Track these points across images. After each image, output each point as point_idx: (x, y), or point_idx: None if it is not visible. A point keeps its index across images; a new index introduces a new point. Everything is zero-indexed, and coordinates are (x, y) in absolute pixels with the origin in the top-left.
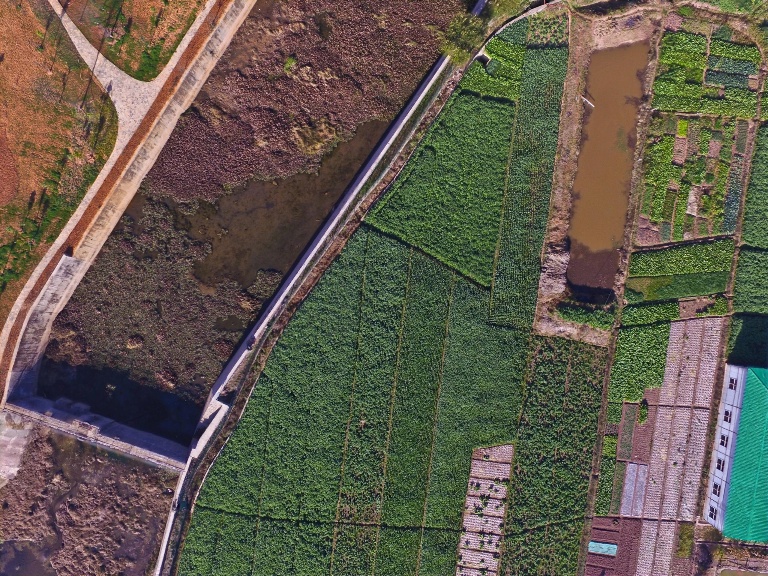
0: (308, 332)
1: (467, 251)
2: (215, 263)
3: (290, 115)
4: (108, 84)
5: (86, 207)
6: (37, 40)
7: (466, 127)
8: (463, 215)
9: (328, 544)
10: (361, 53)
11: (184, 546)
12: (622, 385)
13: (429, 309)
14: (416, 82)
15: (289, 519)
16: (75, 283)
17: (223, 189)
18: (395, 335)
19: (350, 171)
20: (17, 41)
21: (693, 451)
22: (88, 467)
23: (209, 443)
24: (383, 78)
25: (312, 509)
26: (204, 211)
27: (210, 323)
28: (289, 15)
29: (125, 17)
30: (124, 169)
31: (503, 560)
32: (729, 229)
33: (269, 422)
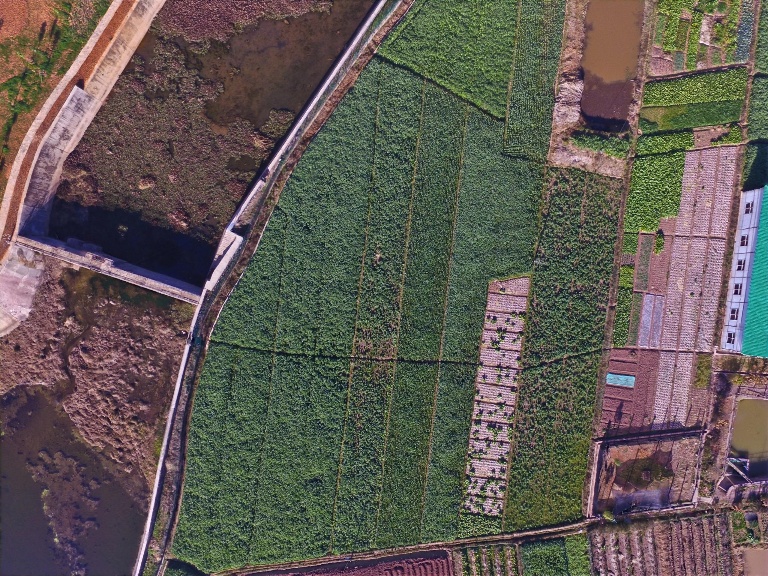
0: (322, 164)
1: (481, 82)
2: (227, 103)
3: None
4: None
5: (97, 39)
6: None
7: None
8: (476, 46)
9: (344, 379)
10: None
11: (199, 382)
12: (638, 214)
13: (443, 140)
14: None
15: (305, 354)
16: (86, 122)
17: (234, 28)
18: (409, 167)
19: (362, 10)
20: None
21: (710, 281)
22: (101, 309)
23: (223, 277)
24: None
25: (328, 344)
26: (215, 50)
27: (223, 163)
28: None
29: None
30: (135, 1)
31: (521, 394)
32: (742, 57)
33: (284, 256)
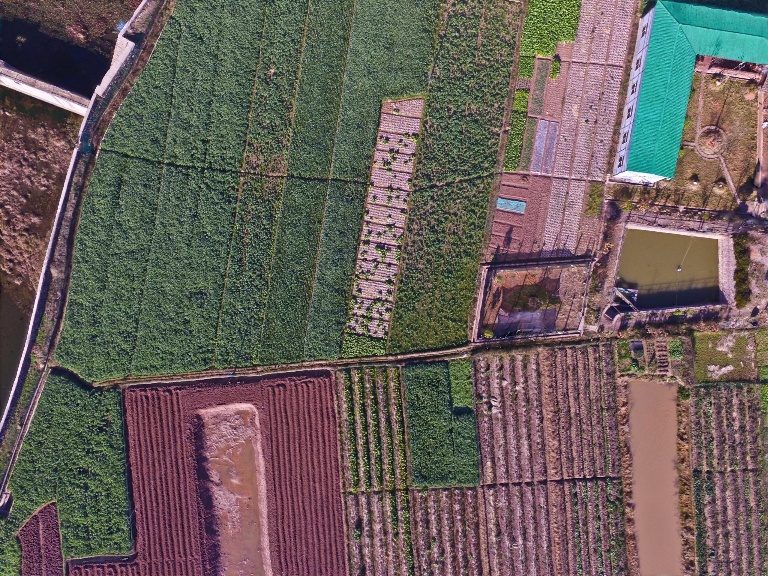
0: None
1: None
2: None
3: None
4: None
5: None
6: None
7: None
8: None
9: (233, 193)
10: None
11: (87, 190)
12: (534, 36)
13: None
14: None
15: (195, 166)
16: None
17: None
18: None
19: None
20: None
21: (605, 109)
22: None
23: (115, 86)
24: None
25: (218, 156)
26: None
27: None
28: None
29: None
30: None
31: (410, 216)
32: None
33: (177, 66)
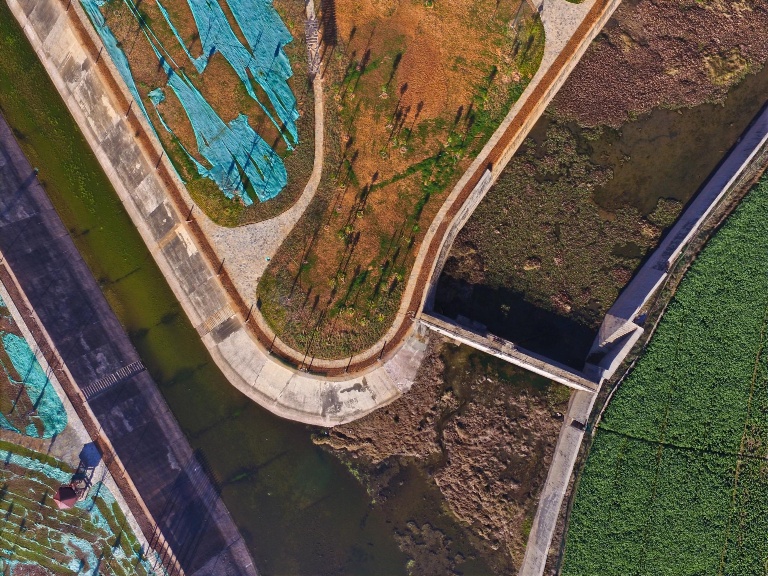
0: (724, 259)
1: None
2: (615, 189)
3: (699, 45)
4: (540, 4)
5: (508, 124)
6: None
7: None
8: None
9: (731, 476)
10: None
11: (585, 469)
12: None
13: None
14: None
15: (693, 448)
16: (478, 202)
17: (628, 116)
18: None
19: (756, 103)
20: None
21: None
22: (478, 386)
23: None
24: None
25: (717, 439)
26: (607, 137)
27: (608, 248)
28: None
29: None
30: (547, 89)
31: None
32: None
33: (678, 348)
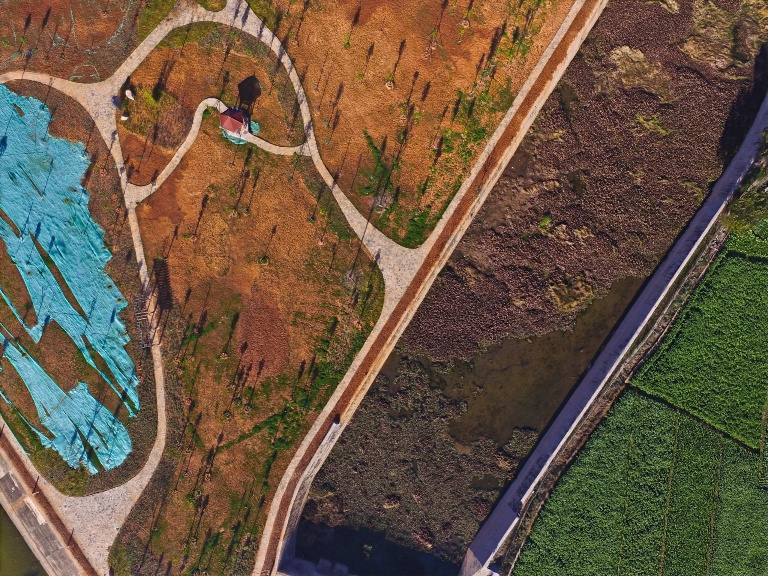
0: (576, 497)
1: (736, 414)
2: (470, 421)
3: (545, 273)
4: (376, 252)
5: (353, 374)
6: (308, 211)
7: (734, 289)
8: (731, 377)
9: None
10: (617, 211)
11: None
12: None
13: (698, 473)
14: (672, 238)
15: None
16: (333, 444)
17: (478, 347)
18: (663, 499)
19: (605, 327)
20: (289, 213)
21: None
22: None
23: None
24: (639, 235)
25: None
26: (459, 369)
27: (466, 482)
28: (543, 173)
29: (393, 186)
30: (390, 335)
31: None
32: None
33: None
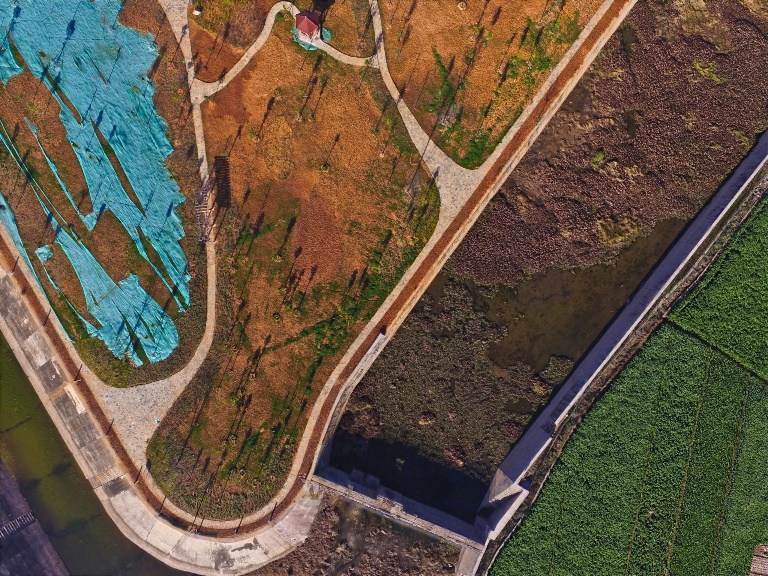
0: (607, 423)
1: (765, 354)
2: (509, 346)
3: (593, 207)
4: (435, 170)
5: (403, 288)
6: (372, 123)
7: None
8: (763, 319)
9: None
10: (667, 152)
11: None
12: None
13: (724, 408)
14: (717, 184)
15: None
16: (375, 357)
17: (523, 275)
18: (689, 431)
19: (645, 265)
20: (353, 123)
21: None
22: (372, 538)
23: None
24: (686, 178)
25: None
26: (503, 295)
27: (501, 404)
28: (599, 110)
29: (457, 106)
30: (442, 253)
31: None
32: None
33: (562, 508)
